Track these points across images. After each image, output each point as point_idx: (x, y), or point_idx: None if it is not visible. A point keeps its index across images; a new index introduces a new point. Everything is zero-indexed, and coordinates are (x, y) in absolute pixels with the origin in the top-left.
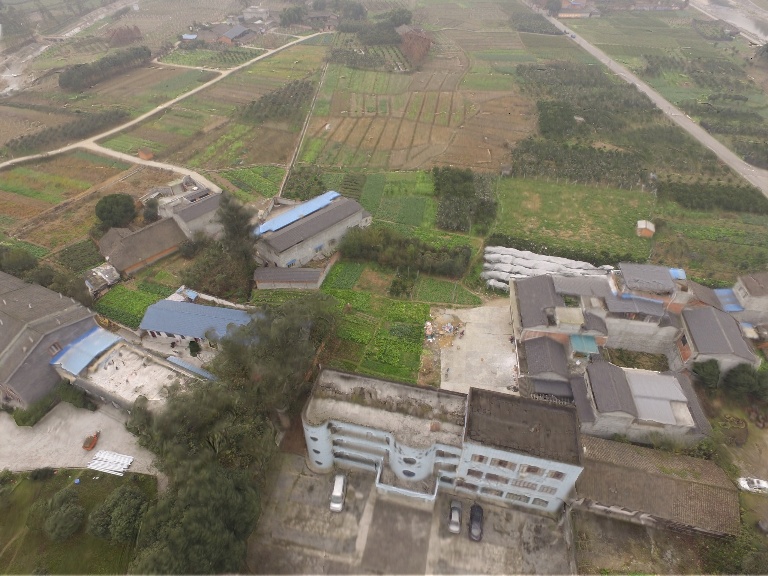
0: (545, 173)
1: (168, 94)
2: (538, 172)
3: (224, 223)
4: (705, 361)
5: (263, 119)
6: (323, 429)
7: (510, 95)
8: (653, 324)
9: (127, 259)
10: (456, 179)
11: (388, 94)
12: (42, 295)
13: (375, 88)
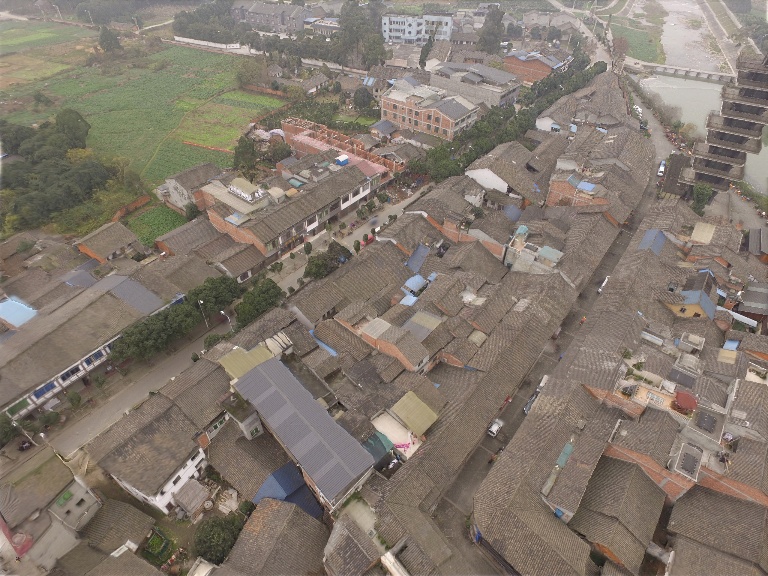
0: (471, 6)
1: None
2: (469, 6)
3: None
4: None
5: None
6: (388, 19)
7: None
8: None
9: None
10: (432, 5)
11: None
12: None
13: None
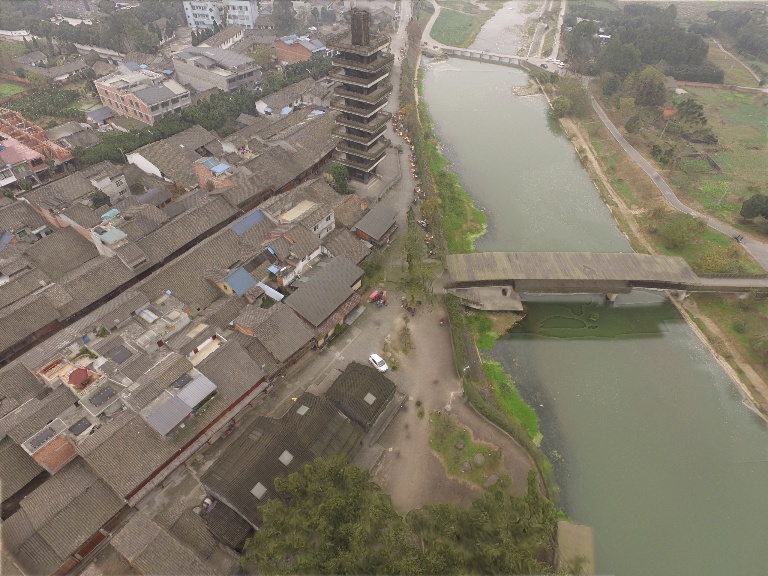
0: None
1: None
2: None
3: None
4: (313, 8)
5: None
6: (188, 4)
7: None
8: (303, 2)
9: (129, 1)
10: None
11: None
12: None
13: None
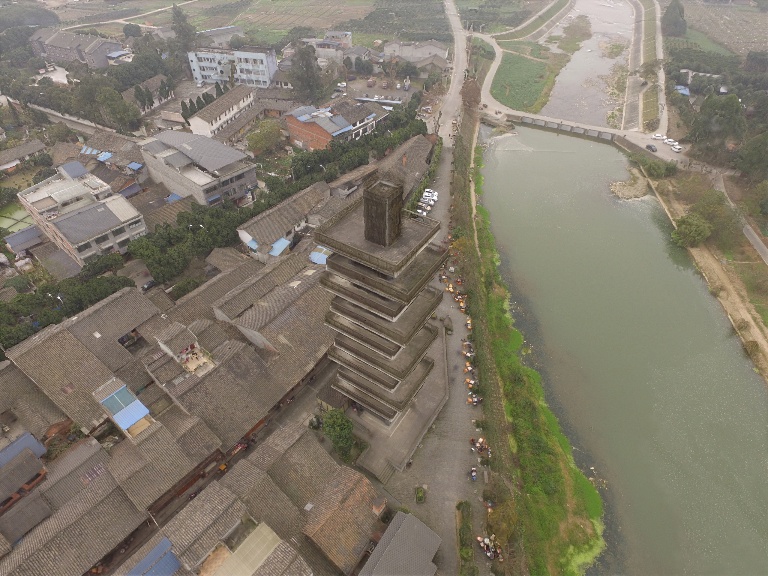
0: (350, 29)
1: (166, 5)
2: (347, 30)
3: (175, 19)
4: None
5: (216, 14)
6: (194, 55)
7: (366, 7)
8: (334, 50)
9: None
10: (301, 29)
11: (294, 6)
12: None
13: (288, 4)
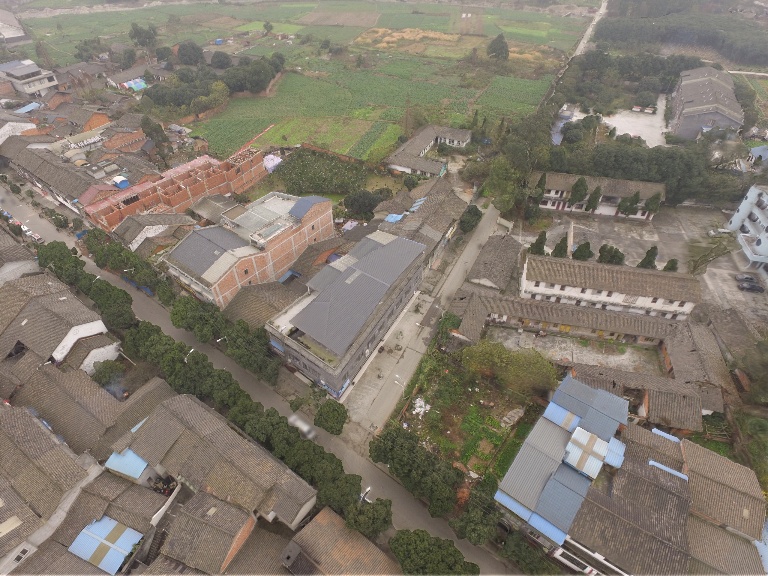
0: None
1: None
2: None
3: None
4: None
5: None
6: (756, 193)
7: None
8: None
9: None
10: None
11: None
12: (736, 106)
13: None
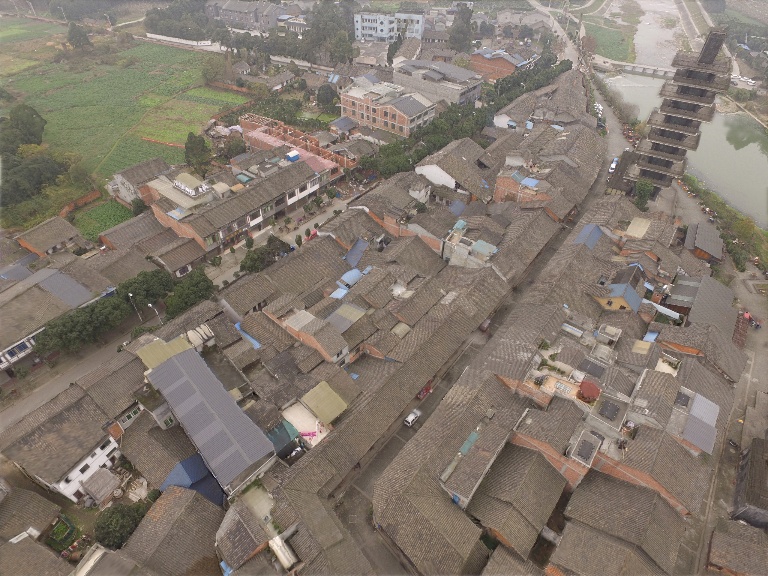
0: (449, 4)
1: None
2: (446, 4)
3: None
4: (473, 22)
5: None
6: (360, 17)
7: None
8: None
9: None
10: (409, 3)
11: None
12: None
13: None
